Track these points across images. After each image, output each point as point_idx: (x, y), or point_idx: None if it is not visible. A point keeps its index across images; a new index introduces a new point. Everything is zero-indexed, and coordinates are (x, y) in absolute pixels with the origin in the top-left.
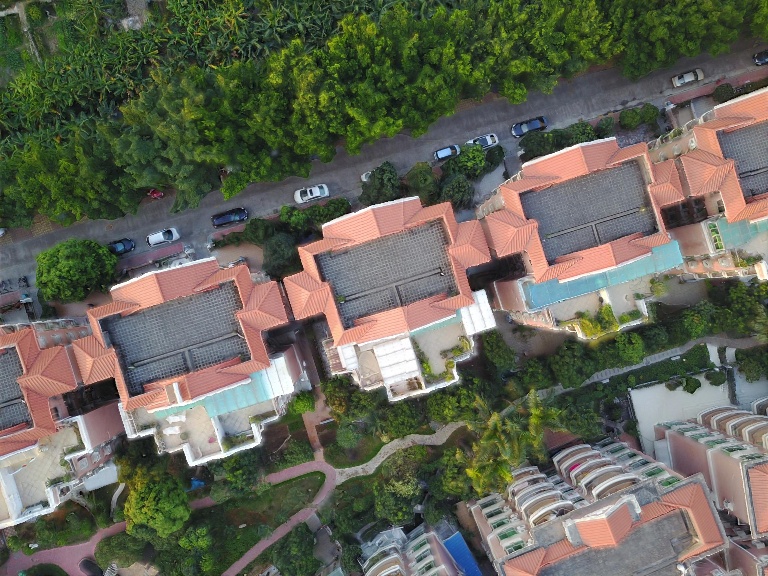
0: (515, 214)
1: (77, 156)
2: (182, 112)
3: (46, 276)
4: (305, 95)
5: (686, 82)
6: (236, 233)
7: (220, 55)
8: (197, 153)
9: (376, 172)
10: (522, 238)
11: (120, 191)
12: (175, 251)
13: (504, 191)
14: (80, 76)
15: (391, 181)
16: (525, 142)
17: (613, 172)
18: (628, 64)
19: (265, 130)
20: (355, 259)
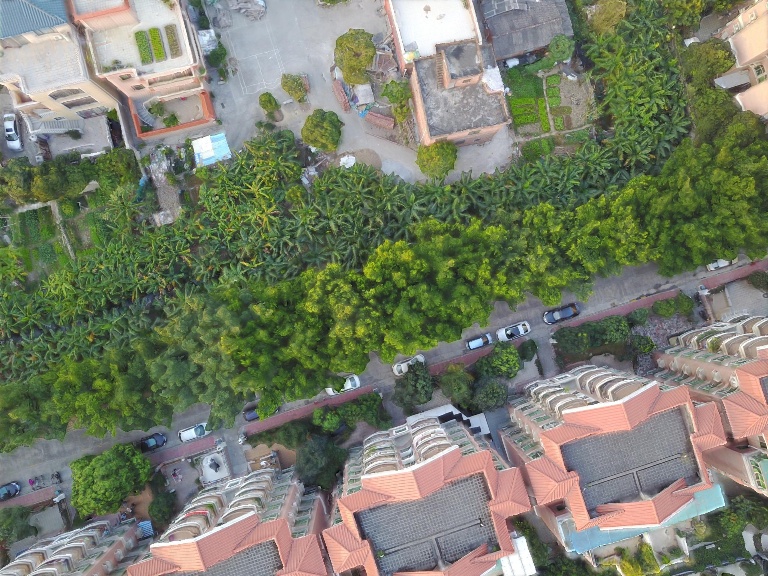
0: (555, 464)
1: (112, 374)
2: (218, 346)
3: (82, 498)
4: (341, 328)
5: (720, 267)
6: (268, 434)
7: (252, 251)
8: (233, 386)
9: (409, 377)
10: (563, 489)
11: (154, 406)
12: (207, 444)
13: (544, 440)
14: (112, 274)
15: (425, 389)
16: (558, 337)
17: (654, 418)
18: (663, 266)
19: (300, 357)
20: (394, 511)
